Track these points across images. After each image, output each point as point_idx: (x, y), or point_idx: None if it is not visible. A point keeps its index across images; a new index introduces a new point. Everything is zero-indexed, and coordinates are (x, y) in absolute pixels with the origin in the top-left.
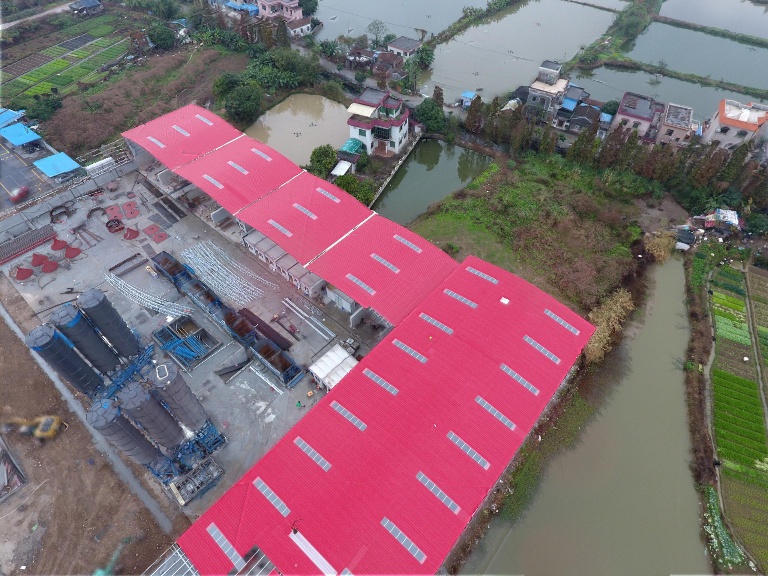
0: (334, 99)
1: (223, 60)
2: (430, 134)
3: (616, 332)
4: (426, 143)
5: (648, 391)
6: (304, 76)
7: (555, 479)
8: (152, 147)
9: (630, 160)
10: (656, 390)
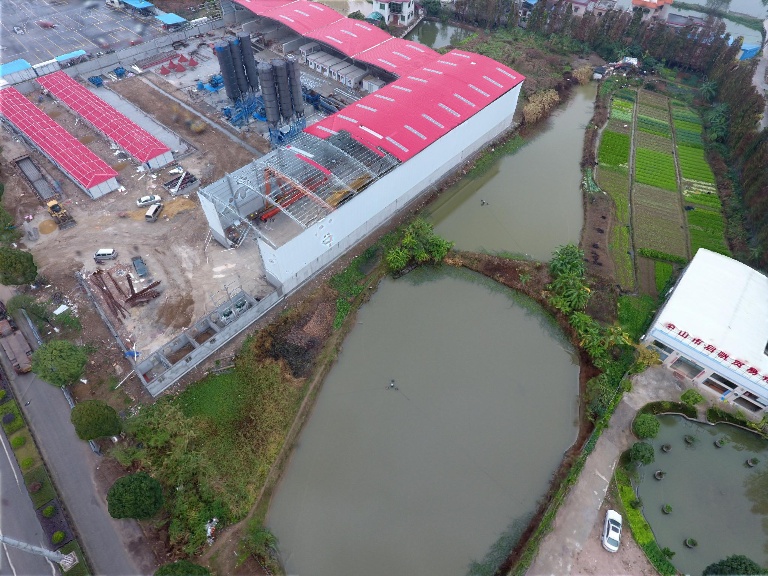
0: None
1: None
2: (430, 17)
3: (546, 112)
4: (427, 25)
5: (562, 137)
6: None
7: (500, 165)
8: (242, 1)
9: (568, 27)
10: (567, 136)
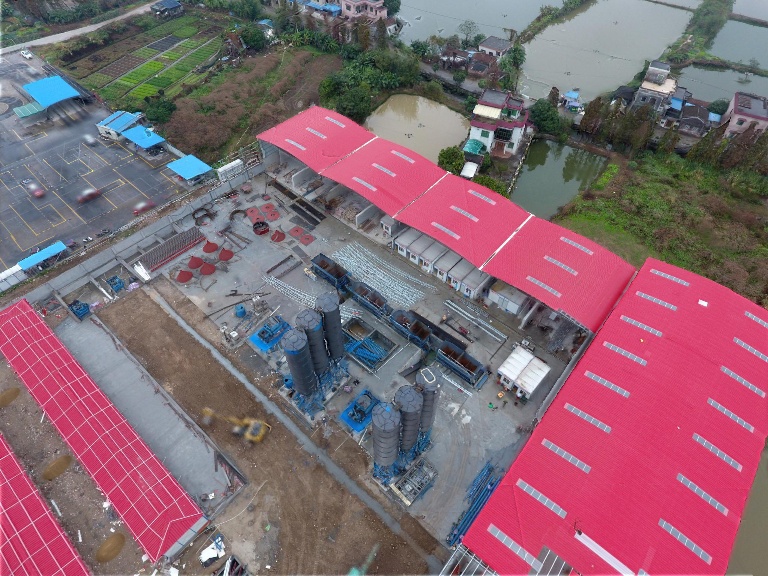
0: (435, 100)
1: (316, 61)
2: (541, 135)
3: None
4: (534, 144)
5: None
6: (405, 77)
7: (757, 480)
8: (293, 150)
9: (756, 160)
10: None
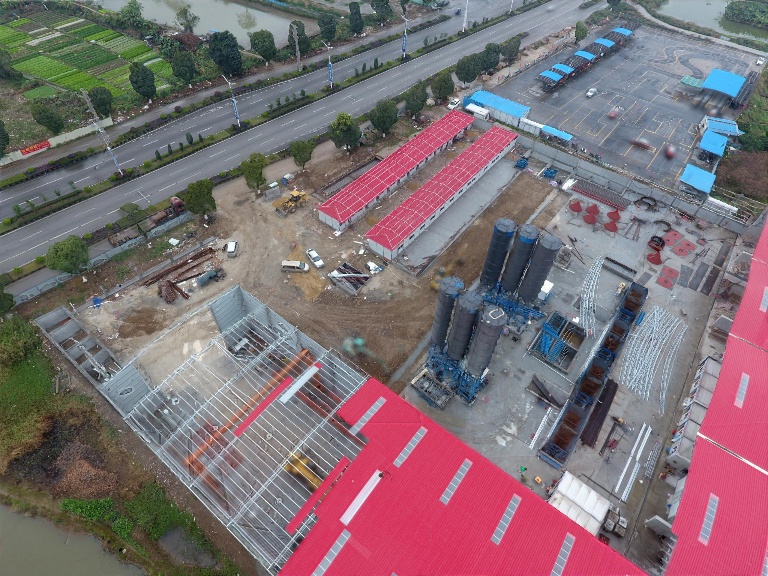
0: None
1: None
2: None
3: None
4: None
5: None
6: None
7: None
8: None
9: None
10: None
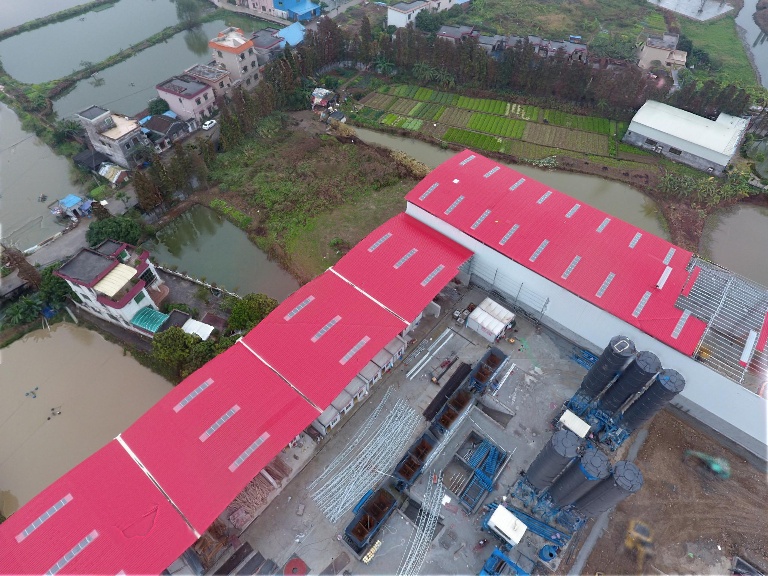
0: None
1: None
2: None
3: None
4: None
5: None
6: None
7: None
8: None
9: None
10: None
